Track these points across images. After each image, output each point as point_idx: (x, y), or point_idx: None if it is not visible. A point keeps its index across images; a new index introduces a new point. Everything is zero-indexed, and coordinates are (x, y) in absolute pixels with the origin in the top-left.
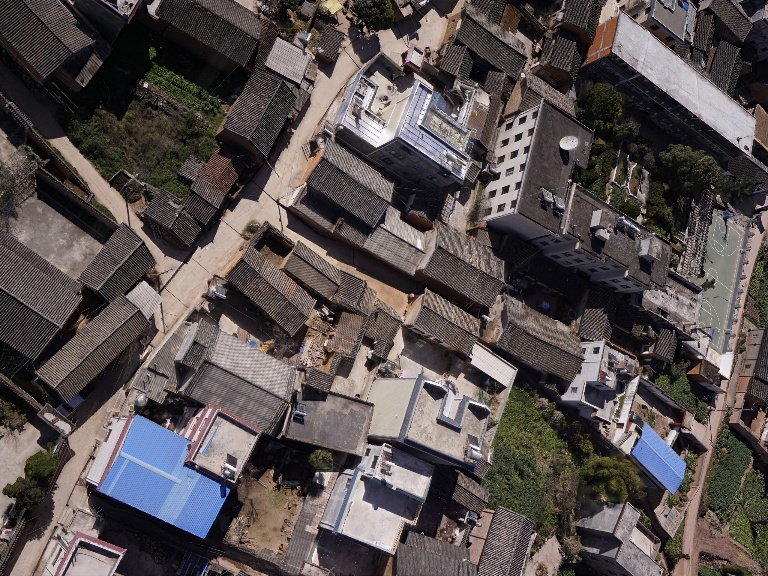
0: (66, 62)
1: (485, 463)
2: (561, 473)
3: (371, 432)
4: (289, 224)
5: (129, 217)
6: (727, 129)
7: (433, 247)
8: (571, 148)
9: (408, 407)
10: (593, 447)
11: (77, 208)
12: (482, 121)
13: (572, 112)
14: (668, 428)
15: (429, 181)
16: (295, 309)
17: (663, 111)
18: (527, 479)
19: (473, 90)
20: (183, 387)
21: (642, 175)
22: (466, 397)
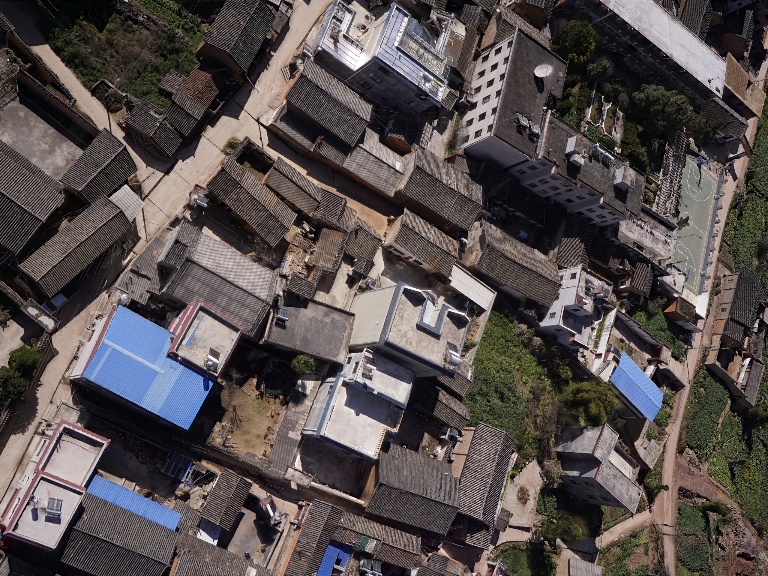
0: None
1: (465, 380)
2: (541, 399)
3: (352, 342)
4: (269, 143)
5: (111, 126)
6: (698, 70)
7: (412, 168)
8: (545, 75)
9: (388, 311)
10: (572, 376)
11: (59, 114)
12: (458, 50)
13: (547, 46)
14: (646, 363)
15: (407, 106)
16: (276, 220)
17: (636, 52)
18: (507, 402)
19: (449, 20)
20: (166, 287)
21: (617, 116)
22: (445, 306)
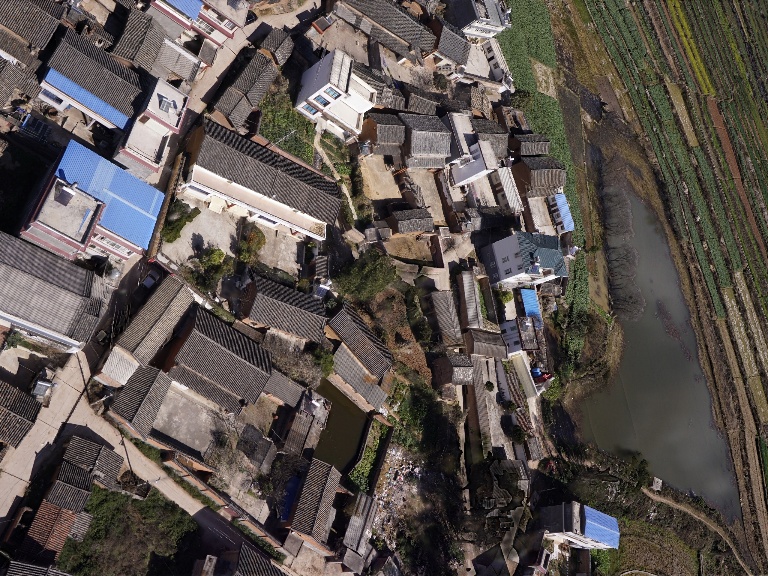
0: (229, 569)
1: None
2: None
3: None
4: None
5: (127, 456)
6: None
7: None
8: None
9: None
10: None
11: None
12: None
13: None
14: None
15: None
16: None
17: None
18: None
19: None
20: None
21: None
22: None
